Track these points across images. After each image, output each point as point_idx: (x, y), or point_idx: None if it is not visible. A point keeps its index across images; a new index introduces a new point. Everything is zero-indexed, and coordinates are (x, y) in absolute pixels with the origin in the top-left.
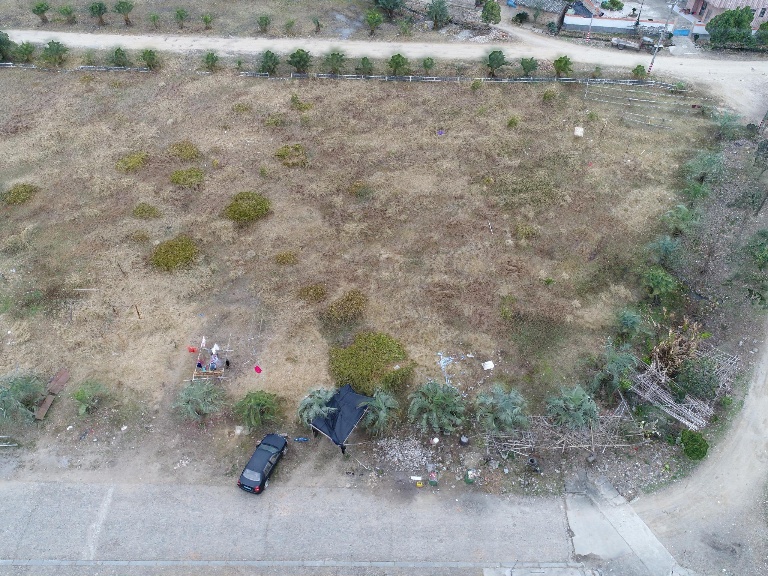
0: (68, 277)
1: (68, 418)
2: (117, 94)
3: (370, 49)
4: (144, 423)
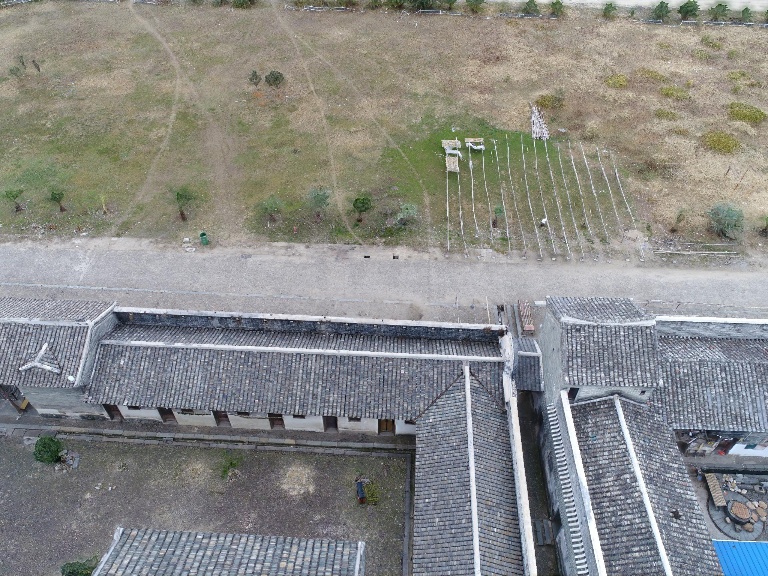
0: (654, 156)
1: (752, 239)
2: (548, 35)
3: (726, 4)
4: None
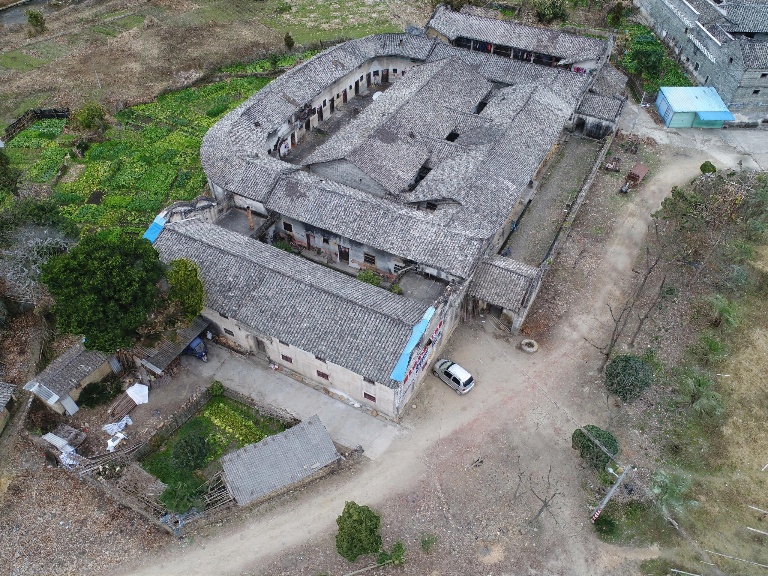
0: None
1: None
2: None
3: None
4: None
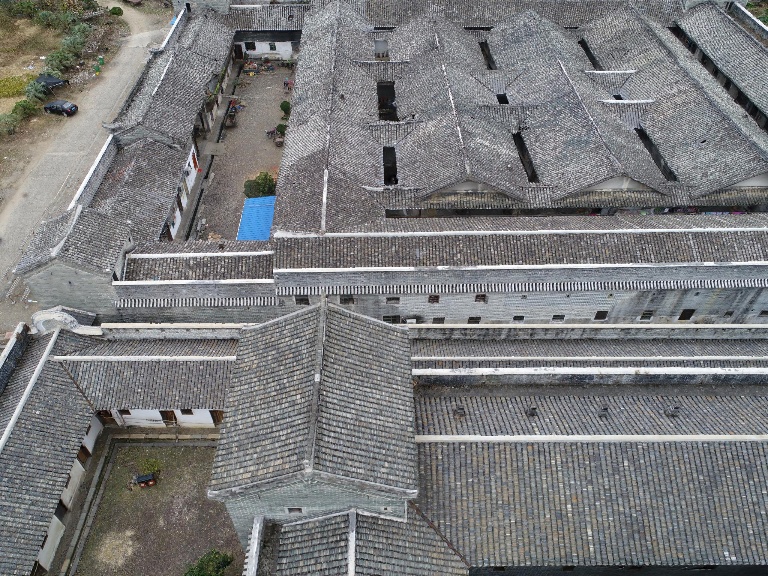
0: None
1: None
2: None
3: None
4: (6, 152)
